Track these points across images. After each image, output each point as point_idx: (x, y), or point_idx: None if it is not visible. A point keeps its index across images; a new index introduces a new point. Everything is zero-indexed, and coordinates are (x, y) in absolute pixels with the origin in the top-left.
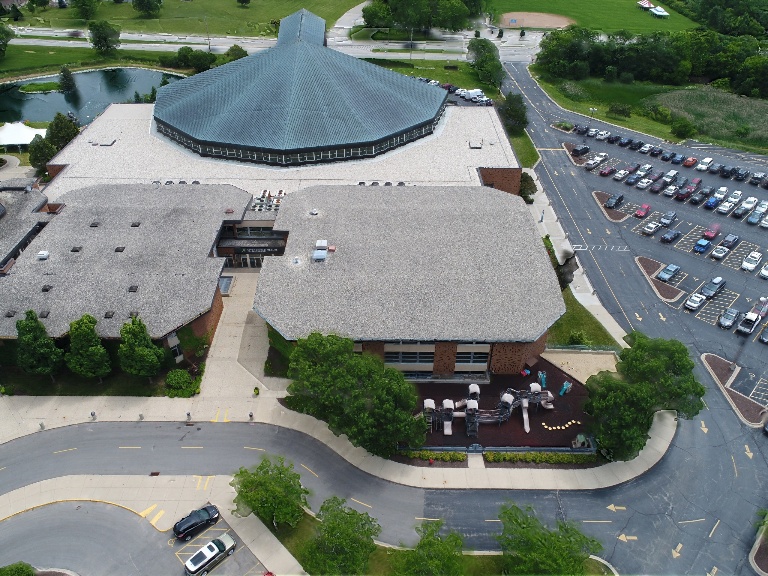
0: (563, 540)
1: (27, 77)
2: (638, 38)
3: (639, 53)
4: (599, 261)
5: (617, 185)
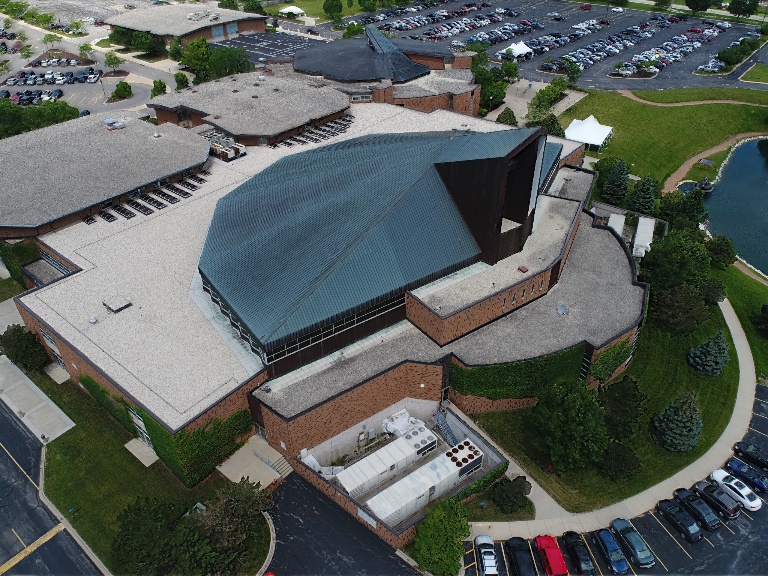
0: None
1: None
2: None
3: None
4: None
5: None
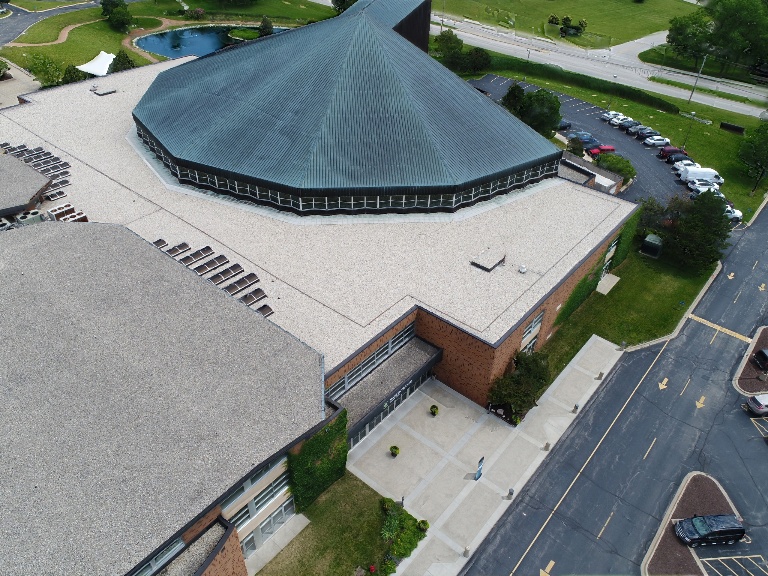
0: None
1: (253, 24)
2: None
3: None
4: None
5: None
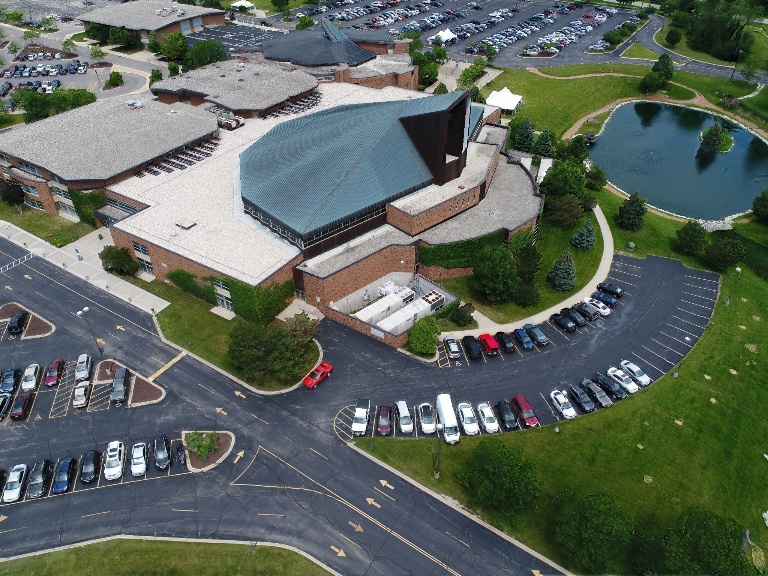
0: None
1: (758, 132)
2: None
3: None
4: (2, 255)
5: (31, 360)
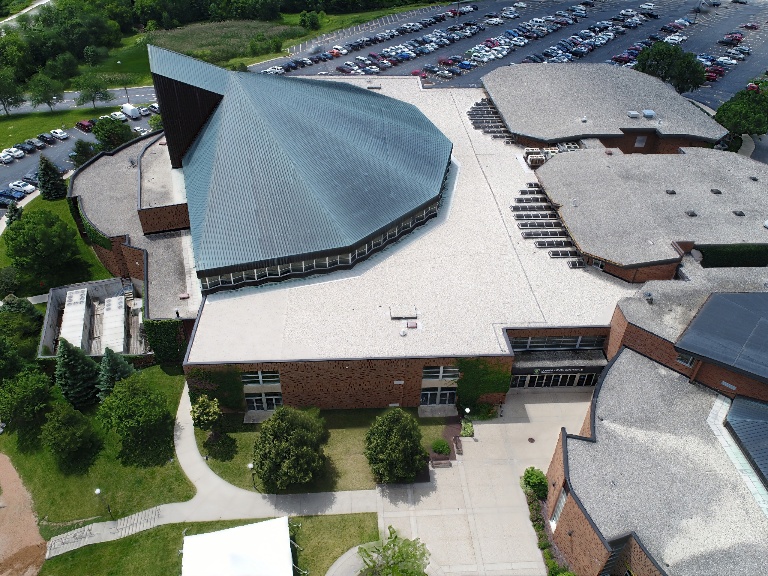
0: (767, 88)
1: None
2: (44, 17)
3: (84, 26)
4: None
5: None
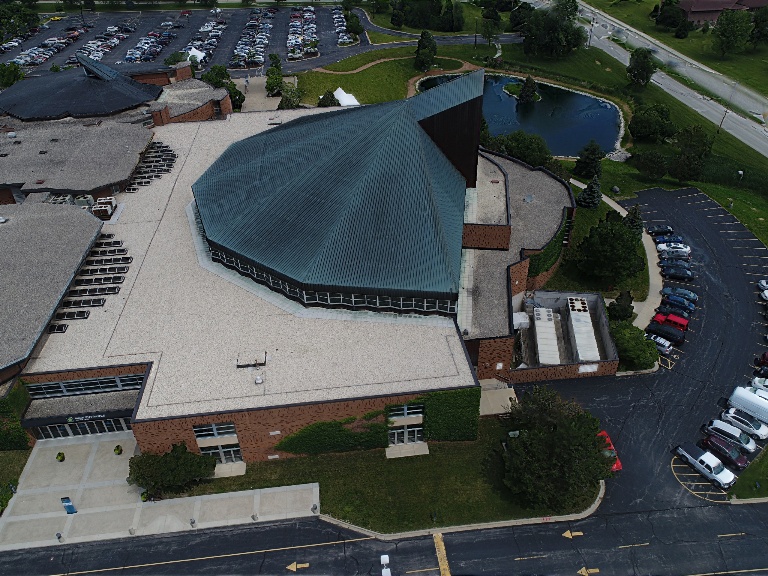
0: None
1: (539, 79)
2: None
3: None
4: None
5: None
